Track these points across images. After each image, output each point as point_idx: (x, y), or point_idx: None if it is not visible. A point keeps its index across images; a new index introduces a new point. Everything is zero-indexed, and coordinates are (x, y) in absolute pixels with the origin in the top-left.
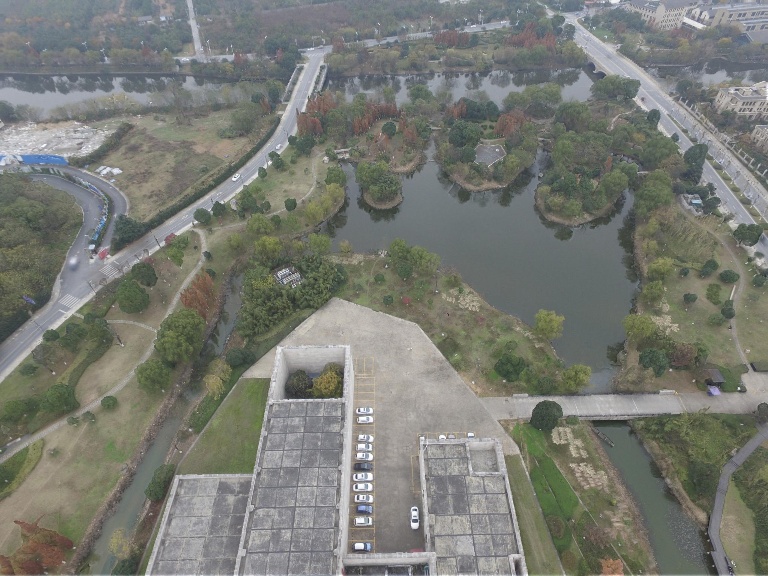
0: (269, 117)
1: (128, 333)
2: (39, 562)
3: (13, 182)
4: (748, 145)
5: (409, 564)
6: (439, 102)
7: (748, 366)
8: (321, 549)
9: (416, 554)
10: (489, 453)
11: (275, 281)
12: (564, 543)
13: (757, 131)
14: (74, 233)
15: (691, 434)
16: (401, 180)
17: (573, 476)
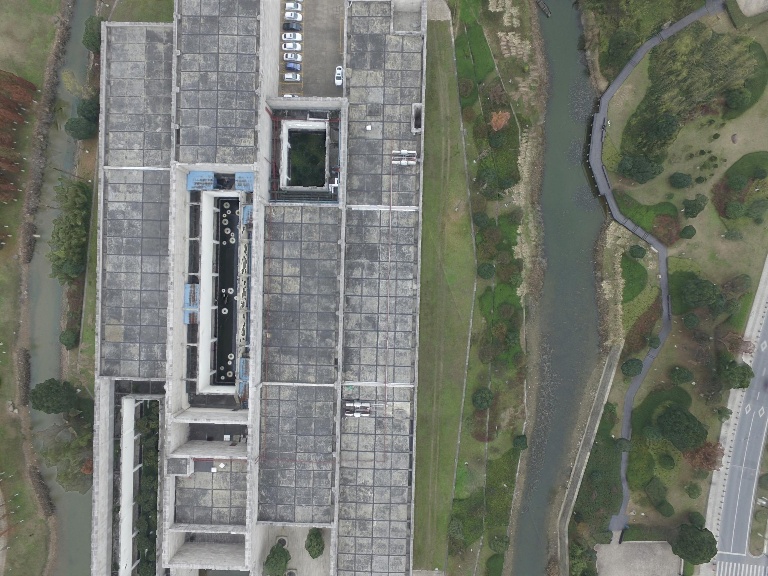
0: None
1: None
2: (13, 100)
3: None
4: None
5: (327, 110)
6: None
7: None
8: (245, 89)
9: (330, 98)
10: (417, 15)
11: None
12: (469, 101)
13: None
14: None
15: (634, 5)
16: None
17: (497, 44)
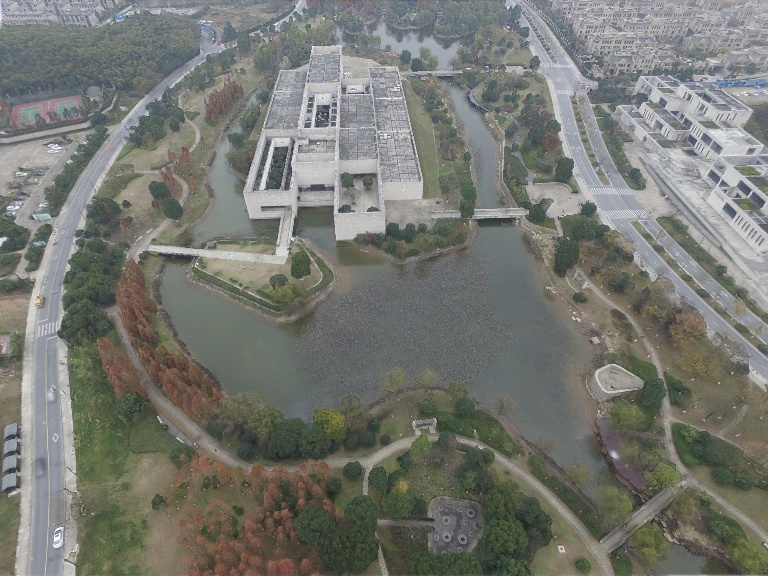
0: (289, 5)
1: (242, 60)
2: None
3: (169, 12)
4: (545, 10)
5: None
6: (388, 1)
7: None
8: None
9: (365, 78)
10: None
11: None
12: None
13: (553, 5)
14: (199, 38)
15: None
16: (364, 22)
17: None
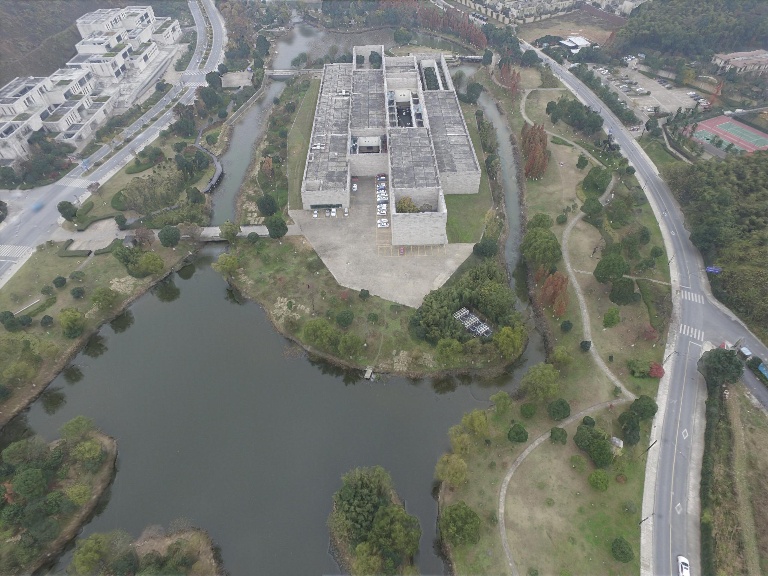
0: None
1: None
2: None
3: None
4: None
5: None
6: None
7: (93, 254)
8: None
9: (355, 155)
10: None
11: (481, 295)
12: None
13: None
14: None
15: None
16: (330, 523)
17: None
